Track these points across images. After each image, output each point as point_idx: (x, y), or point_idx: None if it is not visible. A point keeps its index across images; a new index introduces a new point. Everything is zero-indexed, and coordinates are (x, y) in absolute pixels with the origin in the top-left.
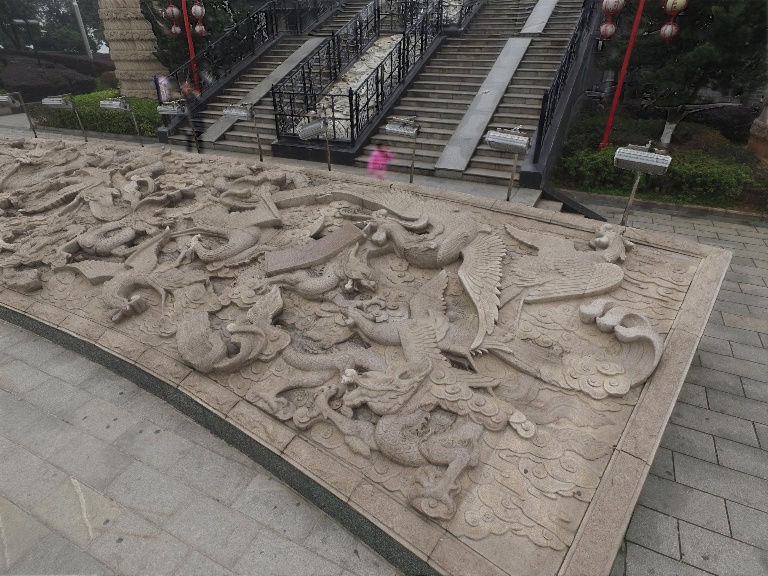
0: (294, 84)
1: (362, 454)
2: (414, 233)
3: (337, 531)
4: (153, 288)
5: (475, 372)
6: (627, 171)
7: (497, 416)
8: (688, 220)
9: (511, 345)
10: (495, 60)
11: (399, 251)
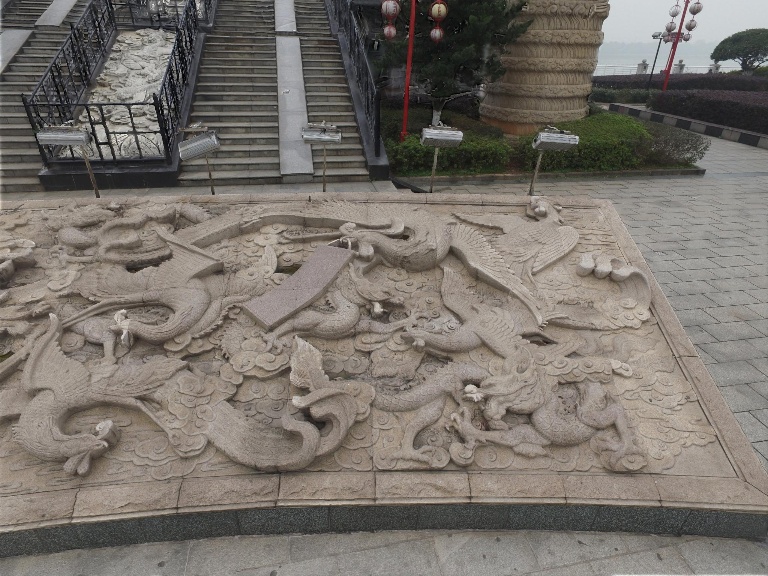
0: (46, 92)
1: (541, 455)
2: (400, 239)
3: (551, 537)
4: (105, 404)
5: (555, 343)
6: (433, 154)
7: (607, 369)
8: (488, 186)
9: (558, 311)
10: (275, 59)
11: (392, 261)
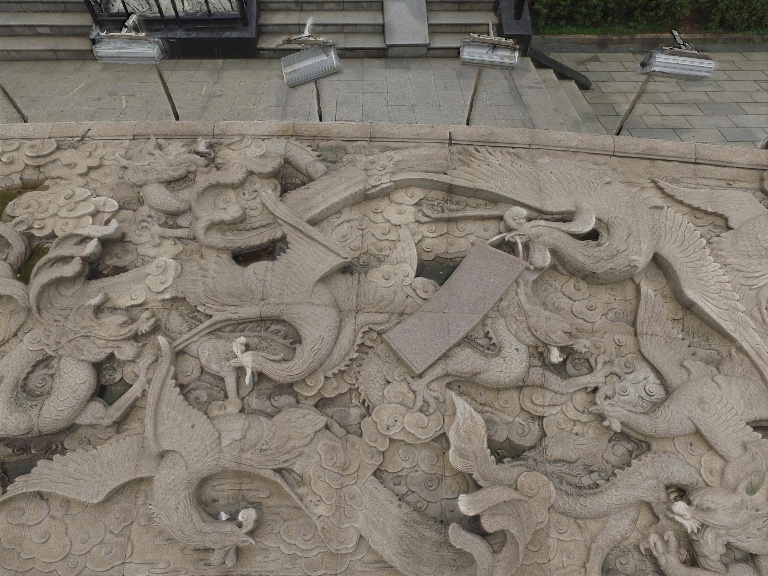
0: None
1: None
2: (588, 241)
3: None
4: None
5: None
6: (584, 2)
7: None
8: None
9: None
10: None
11: (572, 271)
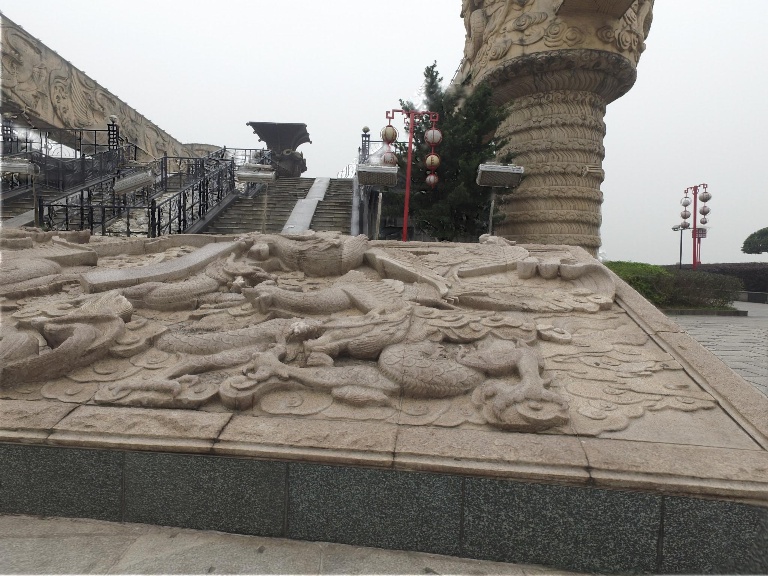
0: None
1: (376, 400)
2: None
3: (371, 555)
4: None
5: None
6: None
7: (525, 325)
8: None
9: None
10: (291, 210)
11: (289, 261)
